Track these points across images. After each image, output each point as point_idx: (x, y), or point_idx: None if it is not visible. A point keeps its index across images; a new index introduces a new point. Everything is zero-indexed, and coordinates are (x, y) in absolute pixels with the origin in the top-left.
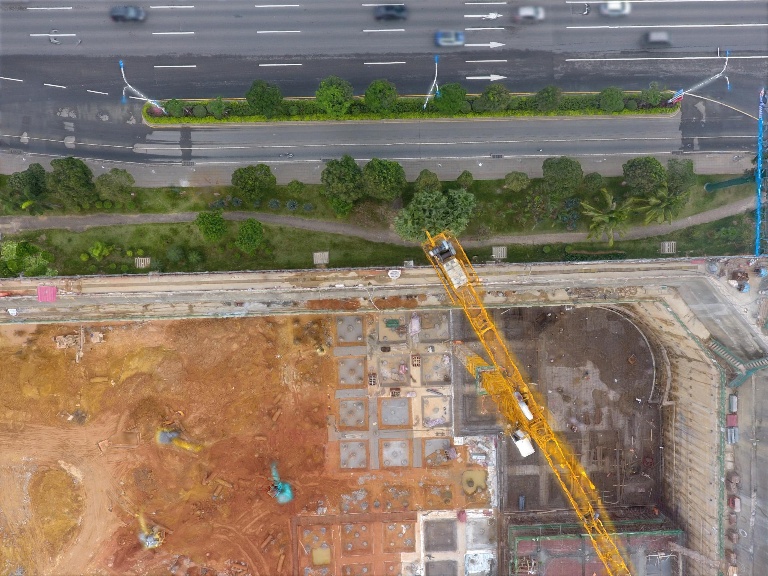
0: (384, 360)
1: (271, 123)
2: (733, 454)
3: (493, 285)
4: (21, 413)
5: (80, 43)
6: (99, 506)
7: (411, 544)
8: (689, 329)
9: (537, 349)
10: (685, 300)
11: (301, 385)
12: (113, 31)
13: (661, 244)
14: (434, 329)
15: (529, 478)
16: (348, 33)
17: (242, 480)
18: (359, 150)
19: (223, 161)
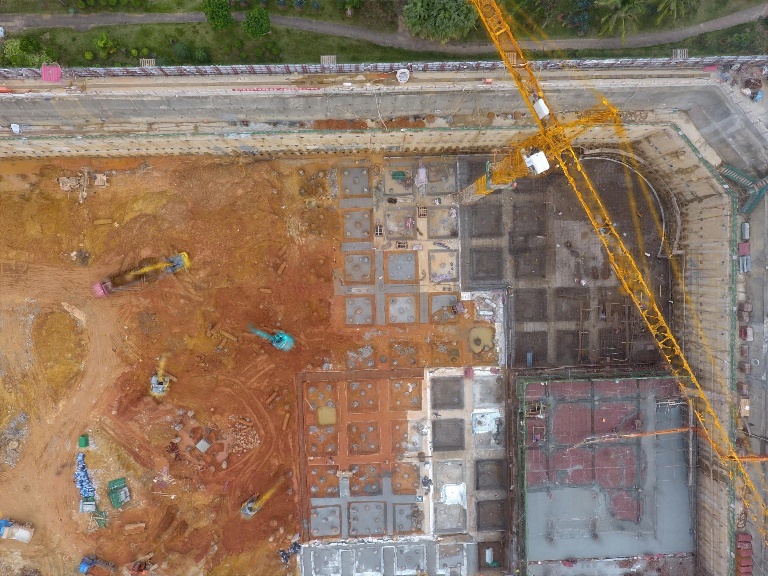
0: (390, 213)
1: None
2: (745, 284)
3: (503, 91)
4: (24, 253)
5: None
6: (102, 351)
7: (417, 403)
8: (700, 155)
9: (545, 201)
10: (696, 125)
11: (306, 237)
12: None
13: (673, 51)
14: (441, 182)
15: (537, 334)
16: None
17: (247, 332)
18: None
19: None
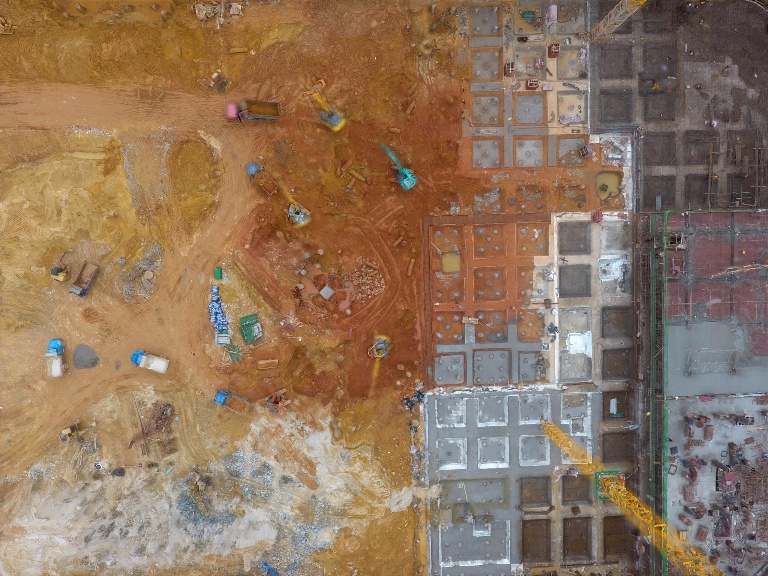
0: (519, 54)
1: None
2: None
3: None
4: (161, 79)
5: None
6: (237, 182)
7: (543, 249)
8: None
9: (676, 41)
10: None
11: (436, 76)
12: None
13: None
14: (570, 22)
15: (666, 177)
16: None
17: (376, 172)
18: None
19: None
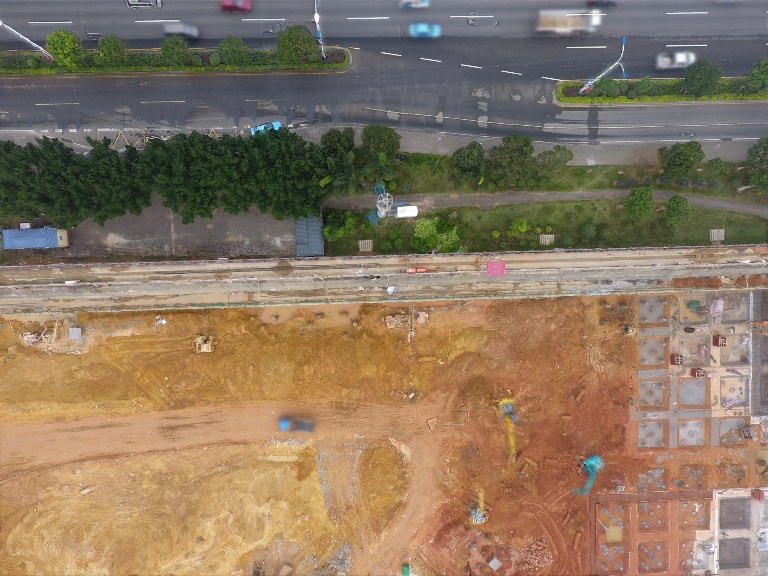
0: (684, 341)
1: (676, 103)
2: None
3: None
4: (355, 391)
5: (497, 24)
6: (425, 483)
7: (703, 522)
8: None
9: None
10: None
11: (605, 365)
12: (529, 13)
13: None
14: (733, 310)
15: None
16: (752, 14)
17: (549, 459)
18: (758, 129)
19: (627, 140)
